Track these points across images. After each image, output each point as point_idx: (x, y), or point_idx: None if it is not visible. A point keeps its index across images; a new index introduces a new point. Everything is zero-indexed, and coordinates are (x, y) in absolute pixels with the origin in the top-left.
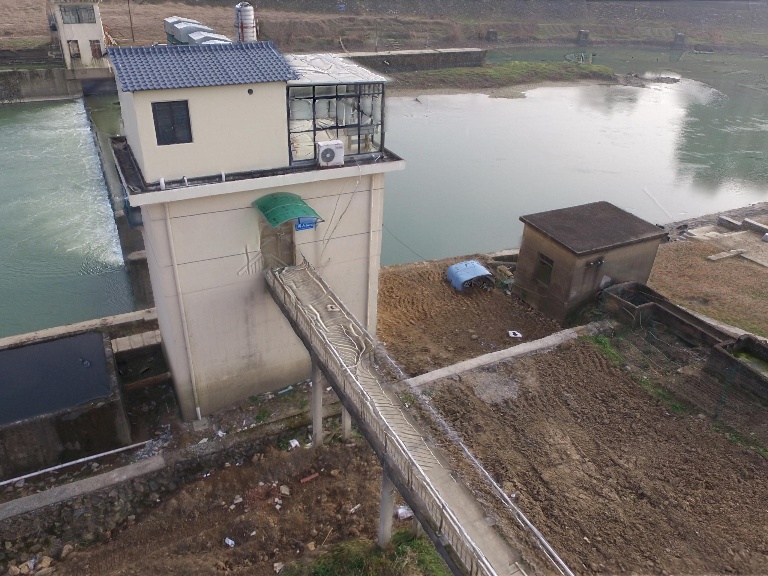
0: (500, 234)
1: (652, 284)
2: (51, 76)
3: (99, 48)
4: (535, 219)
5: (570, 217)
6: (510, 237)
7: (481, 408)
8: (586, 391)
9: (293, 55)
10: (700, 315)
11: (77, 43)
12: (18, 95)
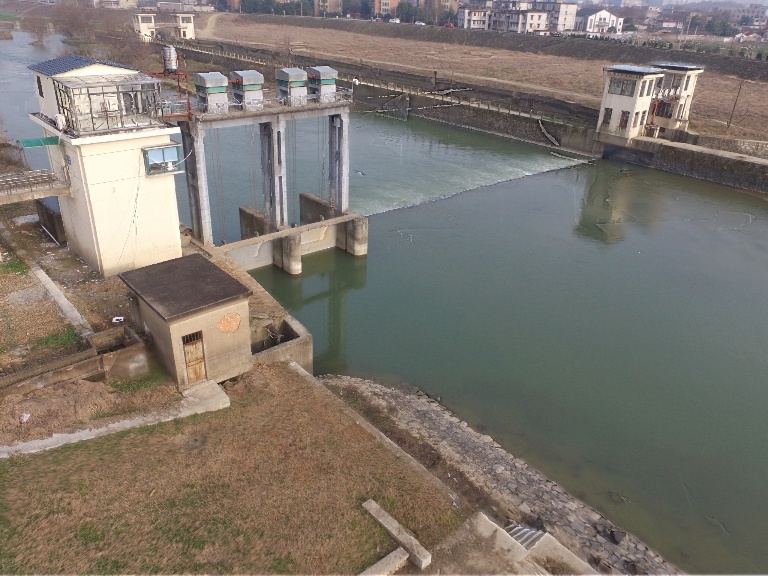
0: (488, 383)
1: (253, 422)
2: (586, 134)
3: (627, 119)
4: (191, 258)
5: (199, 272)
6: (485, 391)
7: (3, 292)
8: (4, 328)
9: (148, 77)
10: (139, 423)
11: (612, 111)
12: (559, 143)
